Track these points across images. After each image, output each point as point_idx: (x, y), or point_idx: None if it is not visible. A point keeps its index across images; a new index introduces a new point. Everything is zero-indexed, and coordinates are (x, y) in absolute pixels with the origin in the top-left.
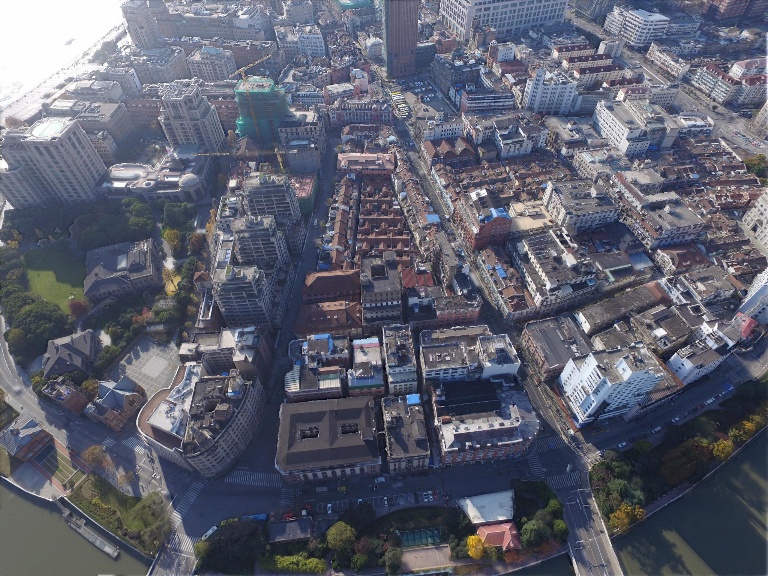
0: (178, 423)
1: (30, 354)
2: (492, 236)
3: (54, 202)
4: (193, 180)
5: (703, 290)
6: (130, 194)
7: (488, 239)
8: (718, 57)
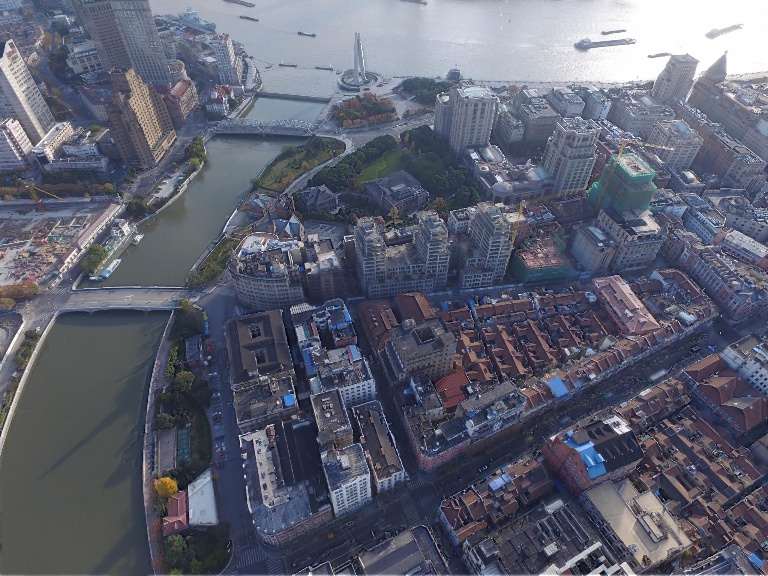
0: (250, 251)
1: (318, 184)
2: (565, 467)
3: (448, 140)
4: (502, 188)
5: None
6: (471, 166)
7: (559, 464)
8: None
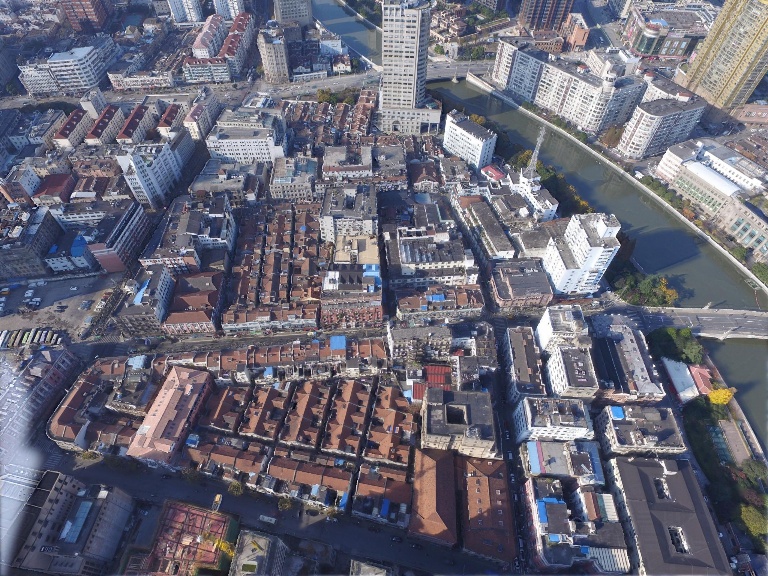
0: None
1: None
2: None
3: None
4: None
5: (464, 177)
6: None
7: None
8: (163, 54)
